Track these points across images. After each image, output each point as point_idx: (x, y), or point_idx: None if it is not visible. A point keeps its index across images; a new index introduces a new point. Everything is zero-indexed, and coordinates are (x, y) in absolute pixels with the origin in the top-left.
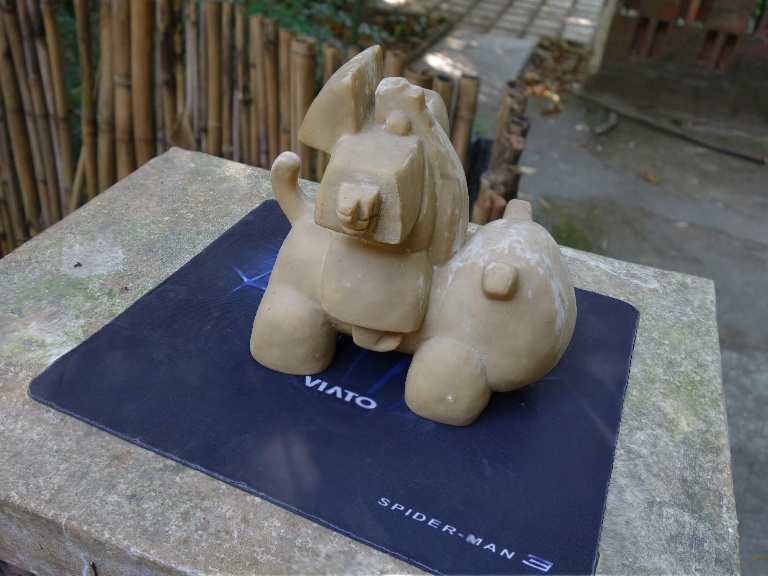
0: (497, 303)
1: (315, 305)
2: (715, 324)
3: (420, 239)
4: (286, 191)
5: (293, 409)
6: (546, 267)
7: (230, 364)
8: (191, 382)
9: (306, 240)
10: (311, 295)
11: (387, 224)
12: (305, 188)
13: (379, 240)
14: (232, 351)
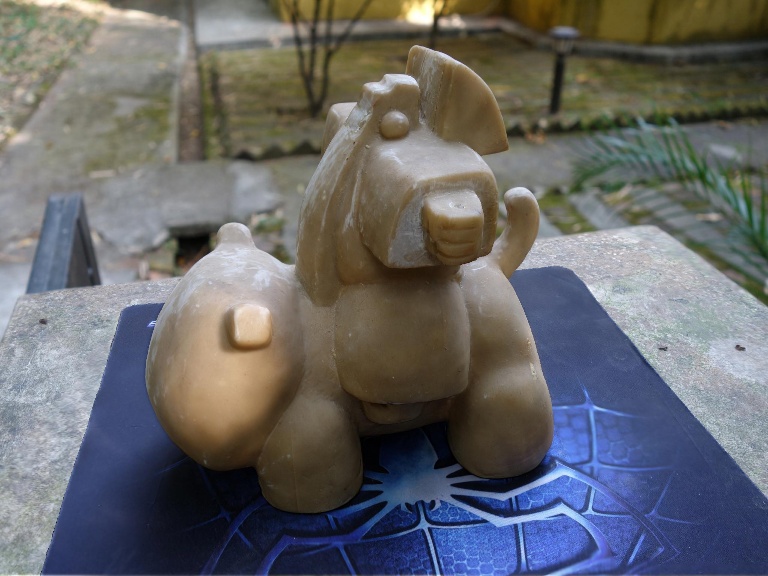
0: None
1: None
2: None
3: None
4: None
5: None
6: None
7: None
8: None
9: None
10: None
11: None
12: None
13: None
14: None
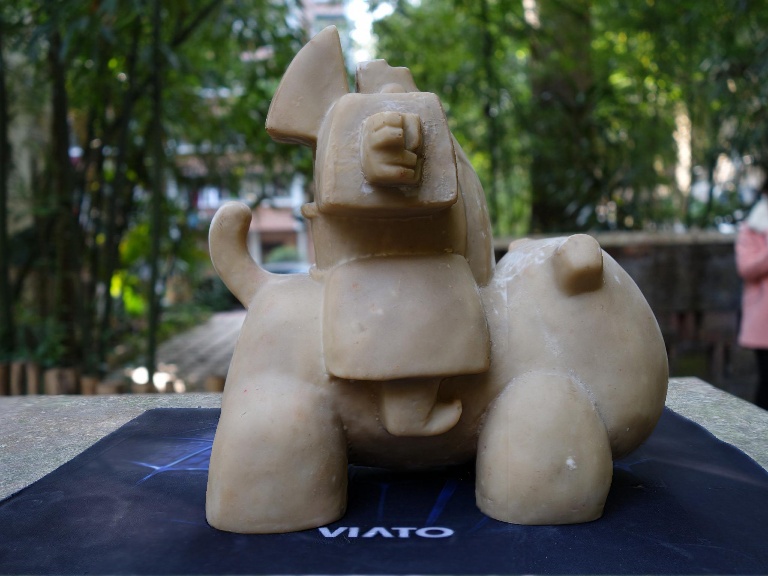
0: (585, 297)
1: (317, 389)
2: (740, 399)
3: (459, 232)
4: (236, 254)
5: (326, 564)
6: None
7: (181, 544)
8: None
9: (285, 295)
10: (309, 373)
11: (435, 171)
12: (195, 398)
13: (427, 201)
14: (176, 531)
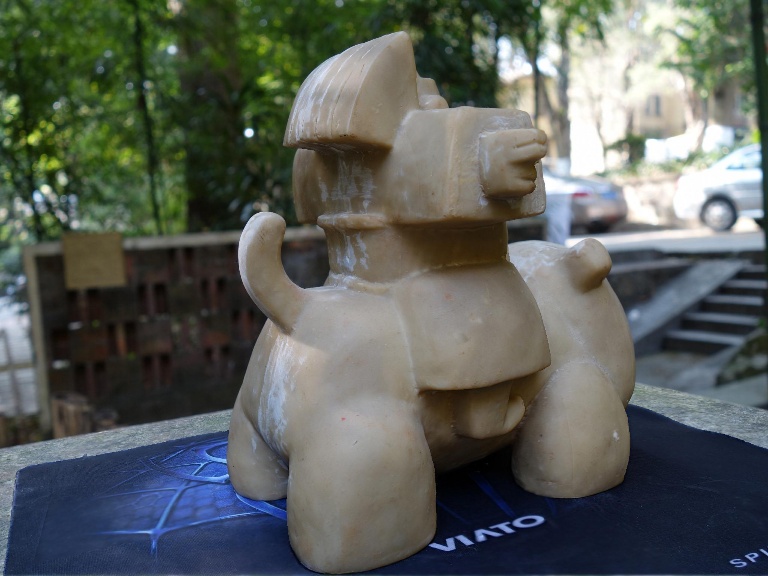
0: (594, 293)
1: (409, 406)
2: None
3: None
4: (277, 270)
5: (492, 574)
6: None
7: None
8: None
9: (358, 312)
10: (401, 390)
11: None
12: (53, 447)
13: (526, 212)
14: None
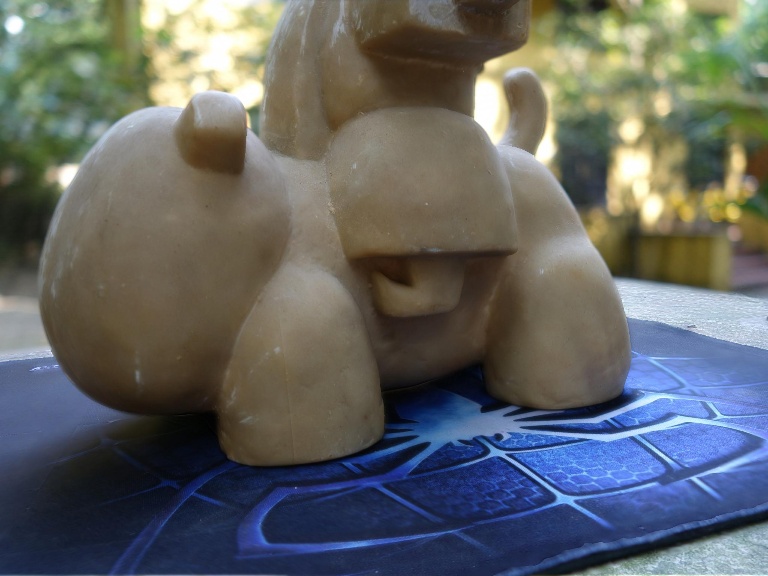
0: None
1: None
2: None
3: None
4: None
5: None
6: None
7: None
8: None
9: None
10: None
11: None
12: None
13: None
14: None
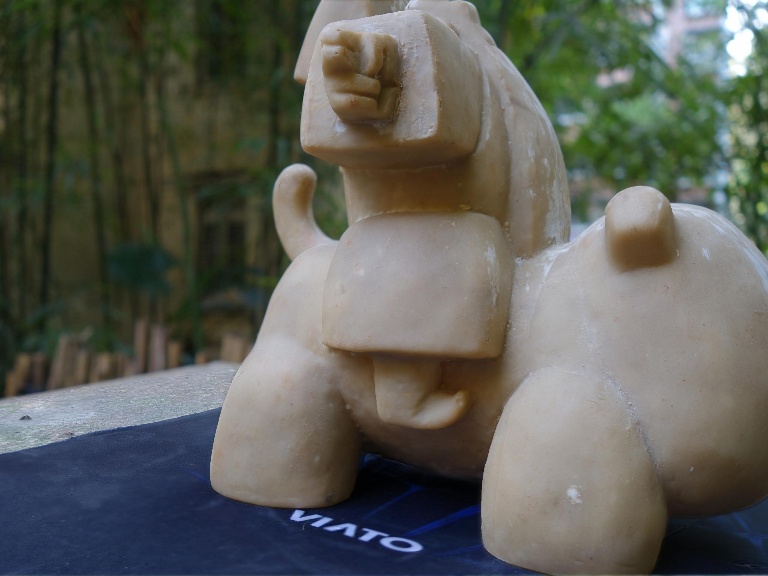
0: (642, 274)
1: (315, 359)
2: None
3: (483, 186)
4: (292, 217)
5: (250, 542)
6: (727, 230)
7: (168, 492)
8: (84, 505)
9: (308, 257)
10: (309, 340)
11: (414, 102)
12: None
13: (402, 139)
14: (181, 481)
